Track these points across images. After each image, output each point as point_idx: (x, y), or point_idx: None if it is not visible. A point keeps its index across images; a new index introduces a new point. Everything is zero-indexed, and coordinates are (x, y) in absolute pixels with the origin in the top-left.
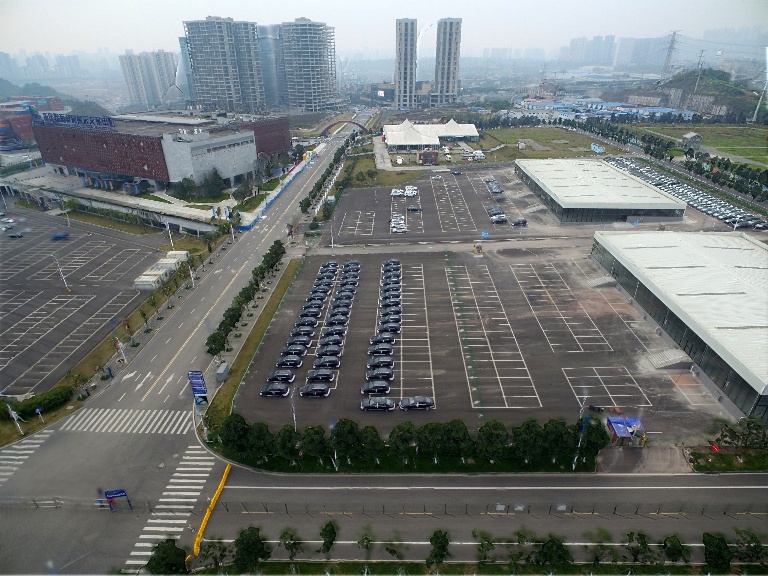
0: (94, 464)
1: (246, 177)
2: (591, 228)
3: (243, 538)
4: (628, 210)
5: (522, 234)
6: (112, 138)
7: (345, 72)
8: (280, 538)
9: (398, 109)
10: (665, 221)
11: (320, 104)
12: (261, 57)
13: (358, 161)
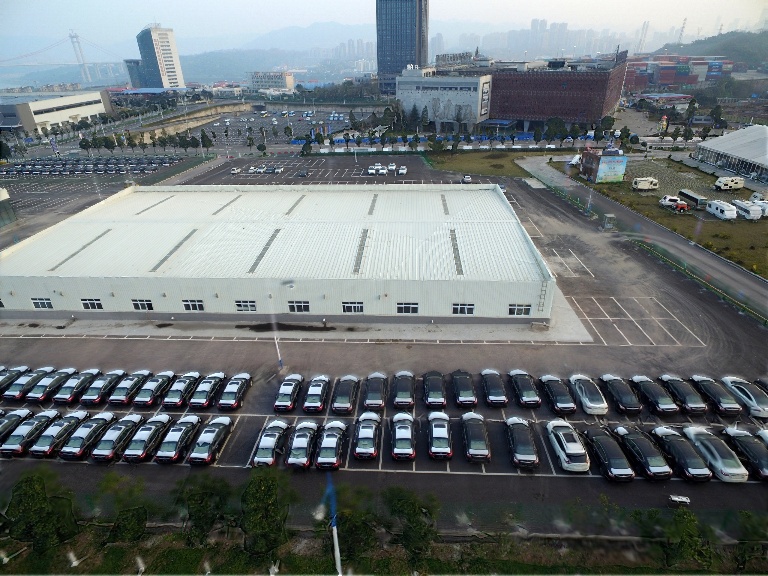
0: None
1: (458, 128)
2: None
3: None
4: None
5: None
6: None
7: None
8: None
9: None
10: None
11: None
12: None
13: None
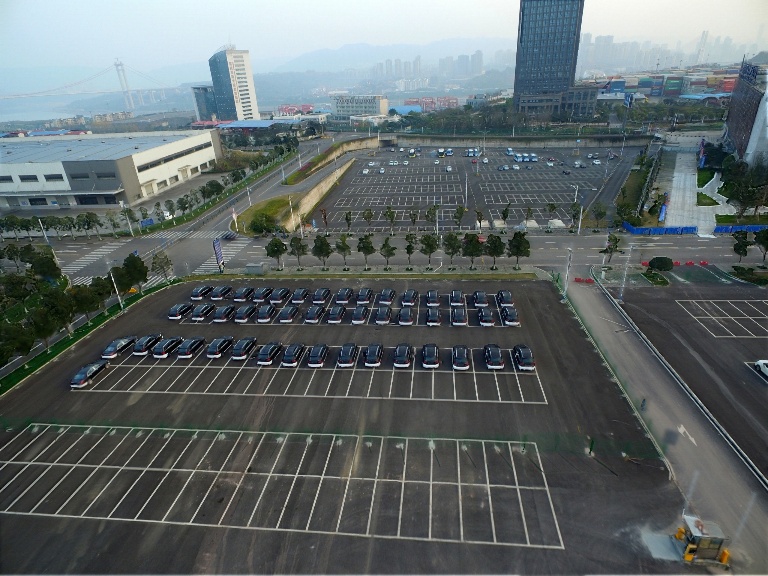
0: (190, 253)
1: None
2: None
3: (12, 275)
4: None
5: None
6: None
7: None
8: (3, 292)
9: None
10: None
11: None
12: None
13: None
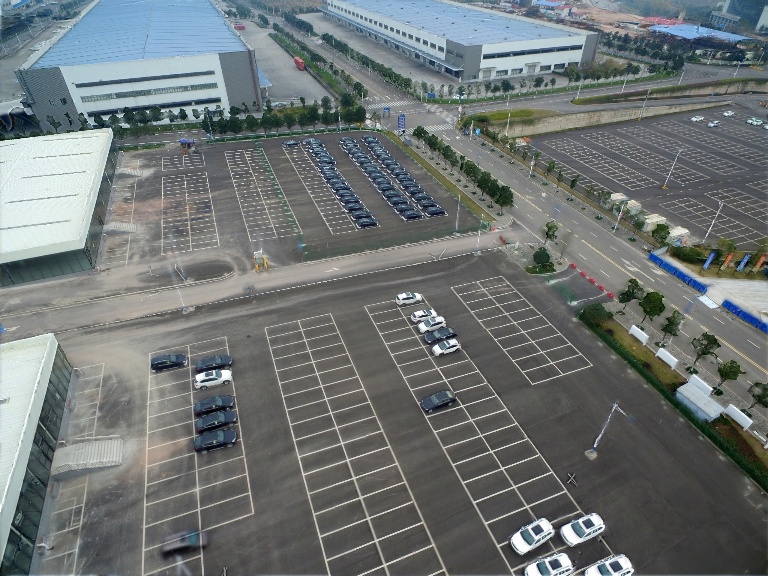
0: (416, 121)
1: None
2: None
3: (327, 97)
4: None
5: (177, 326)
6: None
7: None
8: None
9: None
10: None
11: None
12: None
13: None
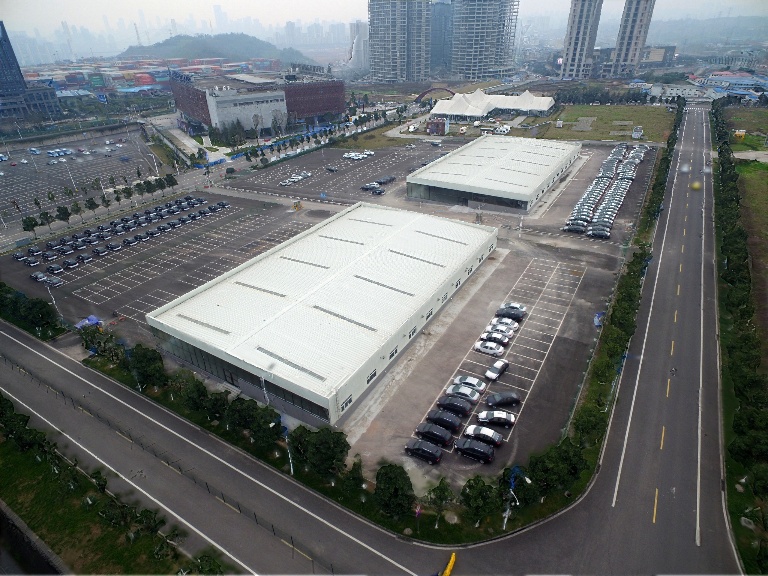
0: None
1: (274, 131)
2: (426, 206)
3: None
4: (468, 193)
5: None
6: (192, 91)
7: (526, 37)
8: None
9: (561, 79)
10: (508, 212)
11: (480, 71)
12: (432, 23)
13: (386, 126)
